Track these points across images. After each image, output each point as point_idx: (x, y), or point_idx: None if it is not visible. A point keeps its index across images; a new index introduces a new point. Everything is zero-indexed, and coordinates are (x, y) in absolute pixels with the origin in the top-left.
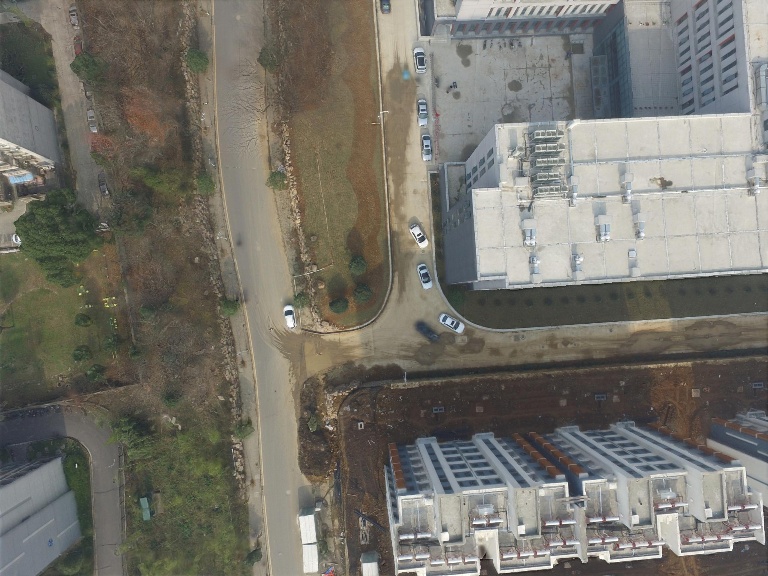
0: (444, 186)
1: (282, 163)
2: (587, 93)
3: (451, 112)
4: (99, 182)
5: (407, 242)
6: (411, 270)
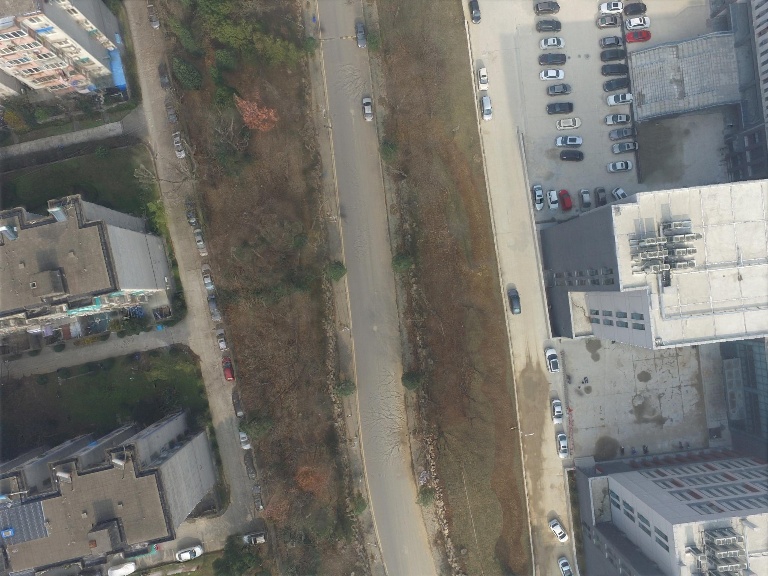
0: (588, 499)
1: (425, 468)
2: (715, 380)
3: (583, 406)
4: (254, 499)
5: (547, 535)
6: (552, 562)
